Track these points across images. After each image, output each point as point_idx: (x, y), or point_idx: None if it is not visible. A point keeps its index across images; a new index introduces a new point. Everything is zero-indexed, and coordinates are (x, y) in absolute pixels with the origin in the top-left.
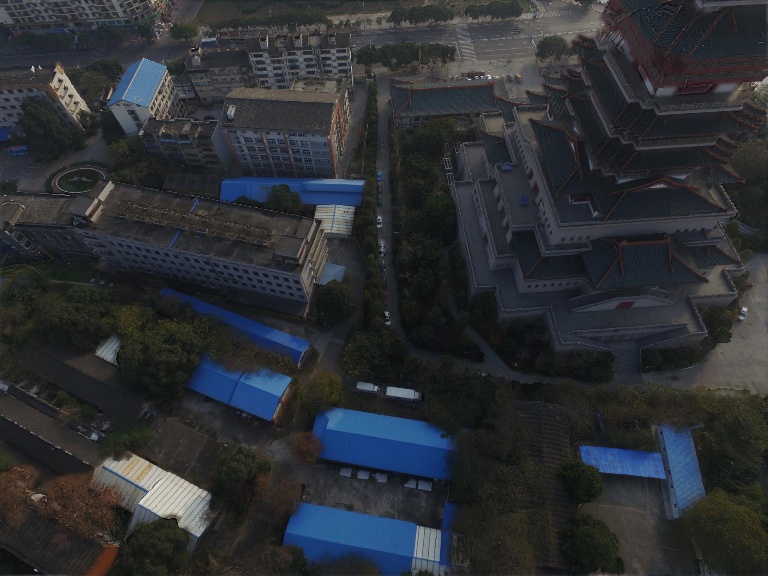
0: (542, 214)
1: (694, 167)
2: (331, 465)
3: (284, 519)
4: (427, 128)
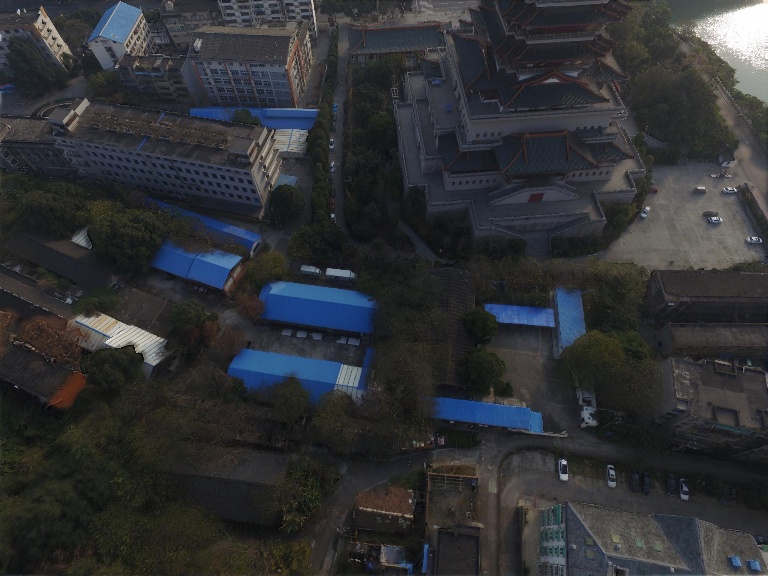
0: (462, 117)
1: (581, 63)
2: (274, 326)
3: (228, 358)
4: (377, 61)
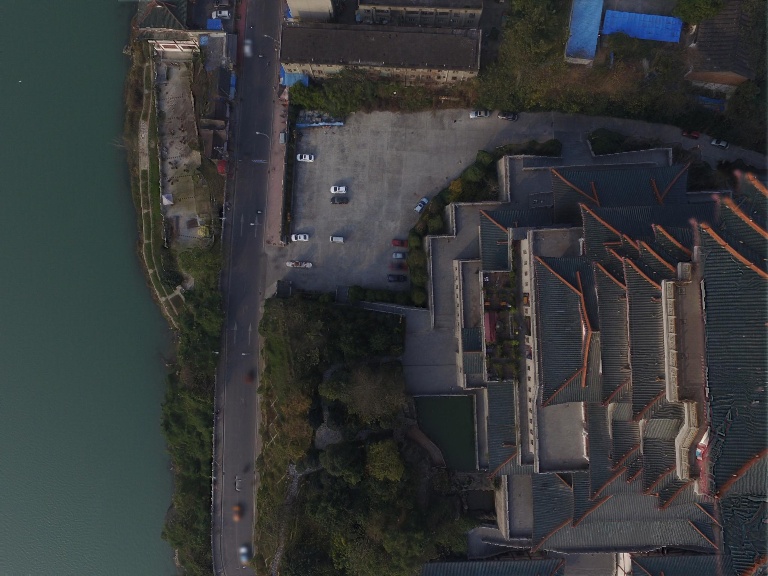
0: None
1: None
2: None
3: None
4: None
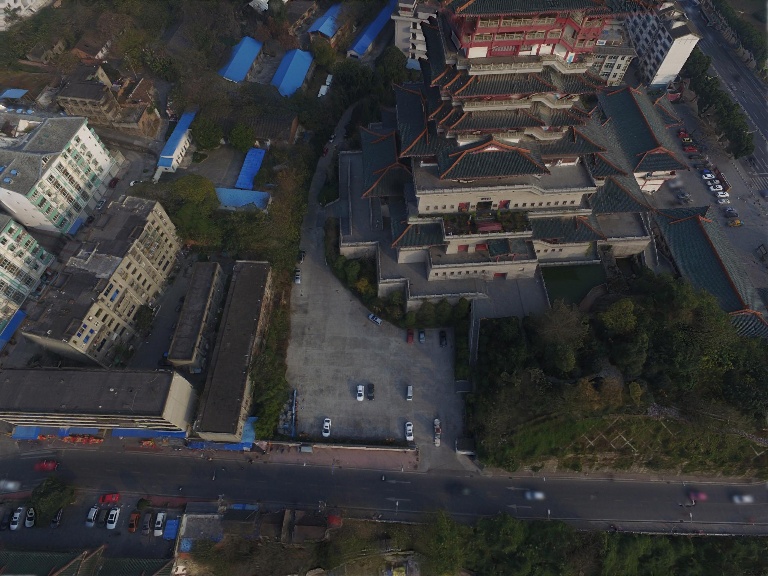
0: None
1: None
2: None
3: None
4: None
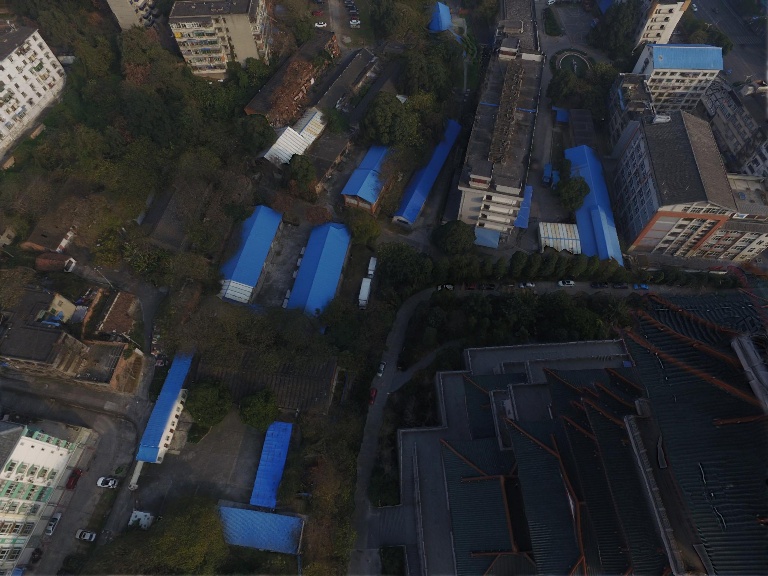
0: None
1: None
2: None
3: None
4: None
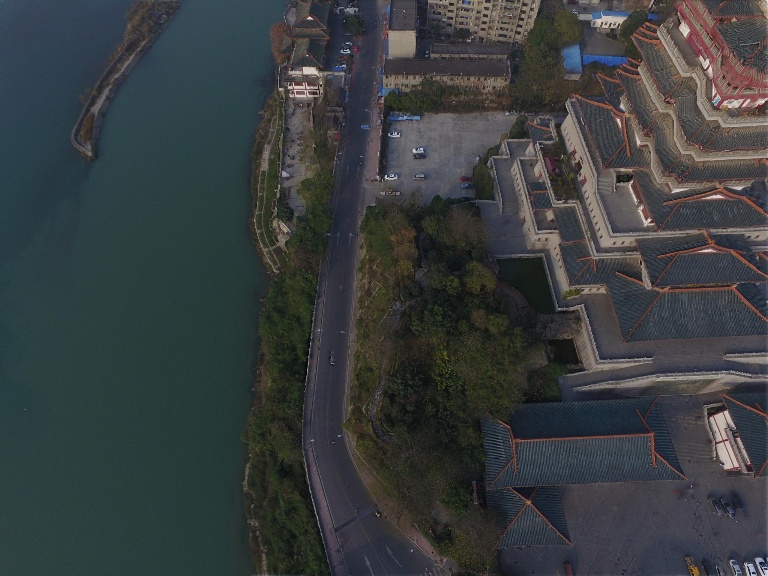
0: None
1: None
2: None
3: None
4: None
